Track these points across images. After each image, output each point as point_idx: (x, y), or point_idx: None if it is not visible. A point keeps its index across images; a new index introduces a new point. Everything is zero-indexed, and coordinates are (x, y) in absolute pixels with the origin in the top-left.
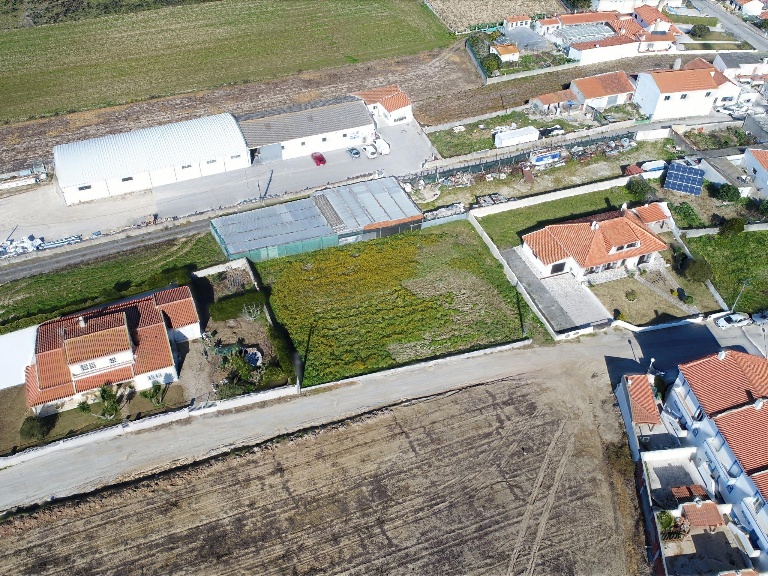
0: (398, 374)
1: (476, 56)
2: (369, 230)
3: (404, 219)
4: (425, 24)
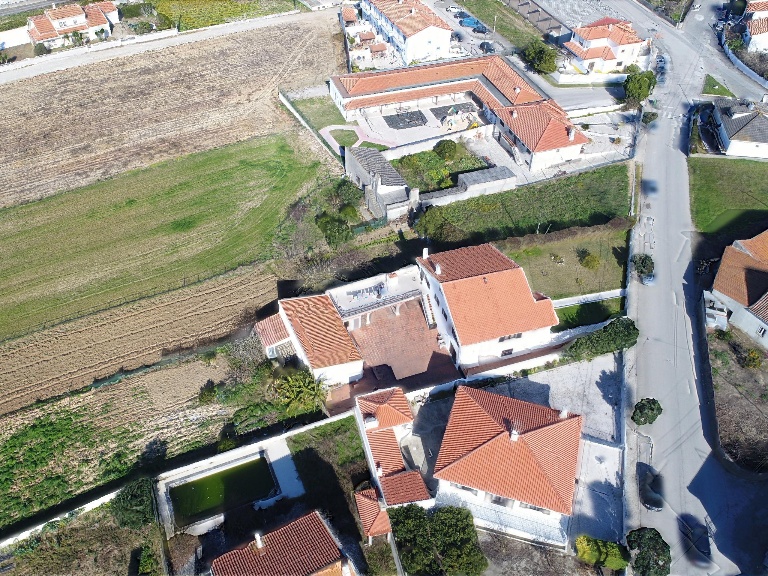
0: (230, 26)
1: None
2: None
3: None
4: None
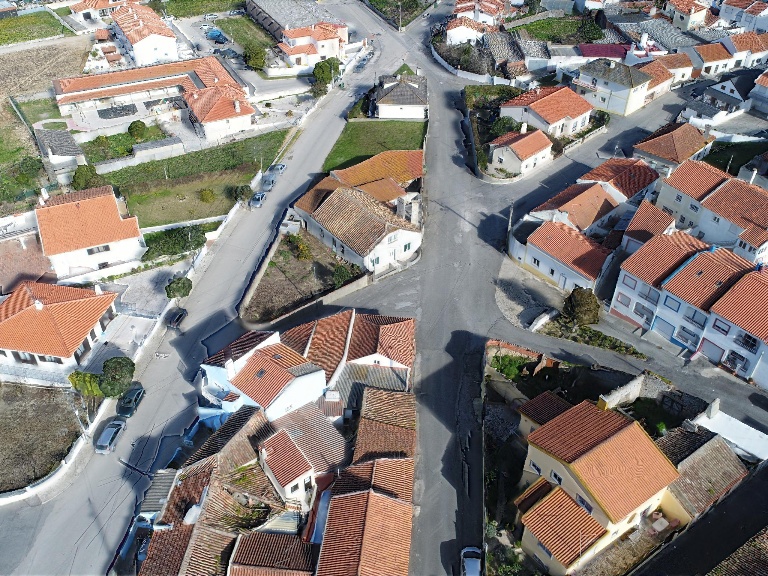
0: None
1: None
2: None
3: (4, 9)
4: None
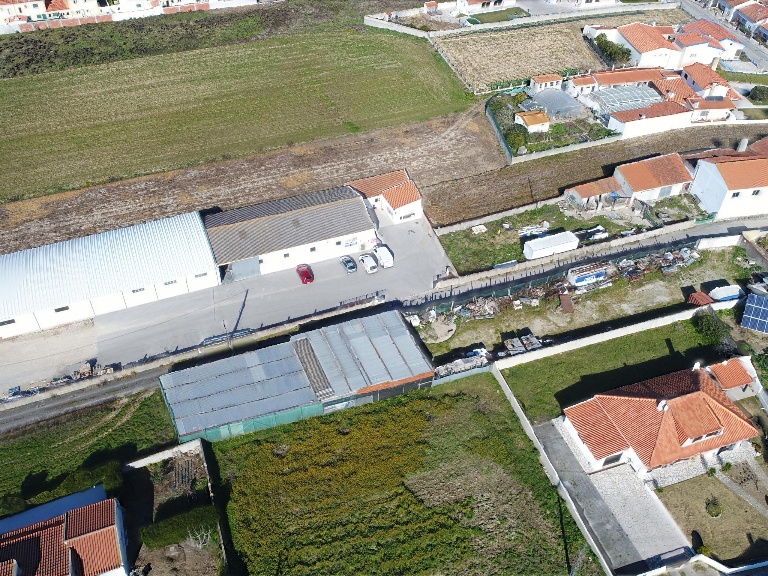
0: None
1: (499, 127)
2: (363, 394)
3: (409, 378)
4: (439, 80)
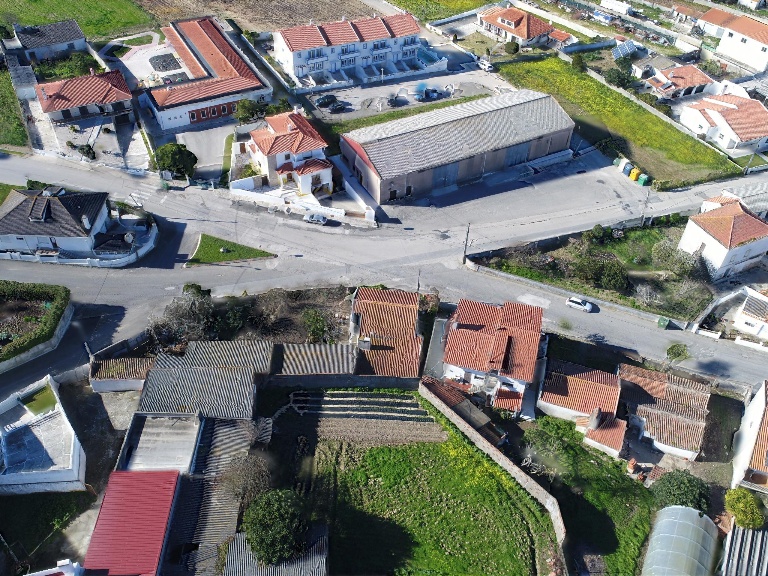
0: None
1: None
2: None
3: None
4: None
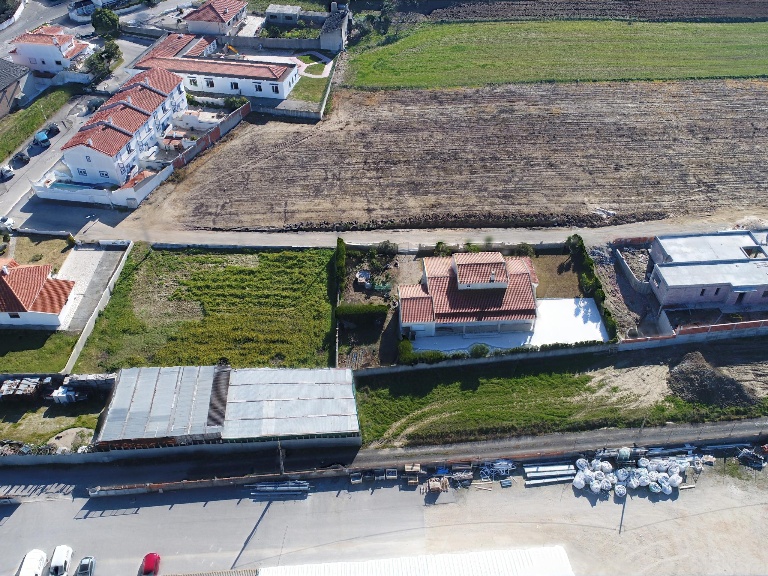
0: None
1: None
2: None
3: None
4: None
